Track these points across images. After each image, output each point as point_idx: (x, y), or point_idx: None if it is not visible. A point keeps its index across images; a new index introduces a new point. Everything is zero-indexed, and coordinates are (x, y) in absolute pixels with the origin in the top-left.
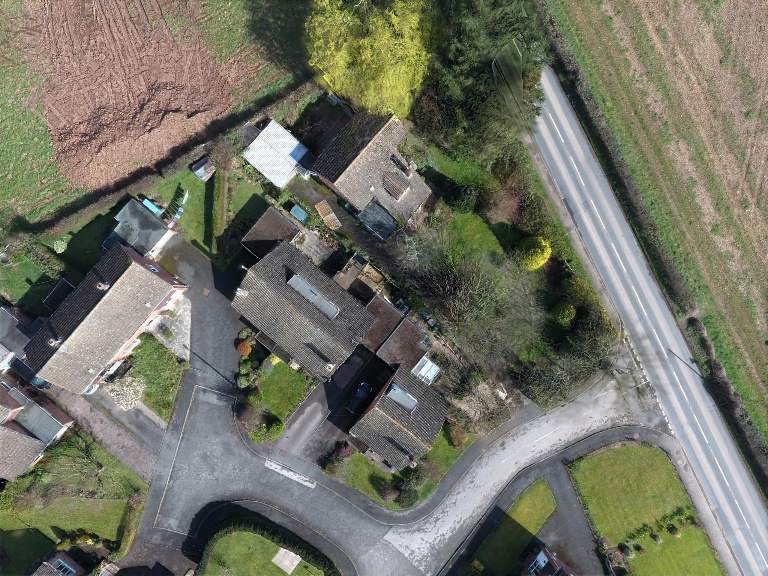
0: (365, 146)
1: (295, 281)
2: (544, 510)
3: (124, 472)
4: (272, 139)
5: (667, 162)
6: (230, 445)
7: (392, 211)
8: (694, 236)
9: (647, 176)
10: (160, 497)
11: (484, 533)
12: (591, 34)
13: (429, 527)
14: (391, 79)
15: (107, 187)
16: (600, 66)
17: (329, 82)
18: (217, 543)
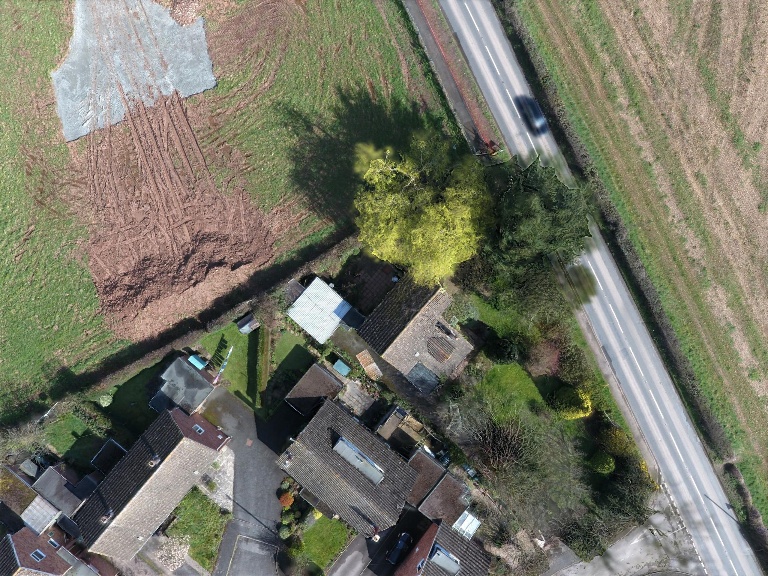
0: (412, 318)
1: (341, 447)
2: None
3: None
4: (316, 297)
5: (705, 308)
6: None
7: (435, 371)
8: (731, 382)
9: (685, 322)
10: None
11: None
12: (630, 181)
13: None
14: (440, 260)
15: (151, 338)
16: (639, 213)
17: (377, 255)
18: None
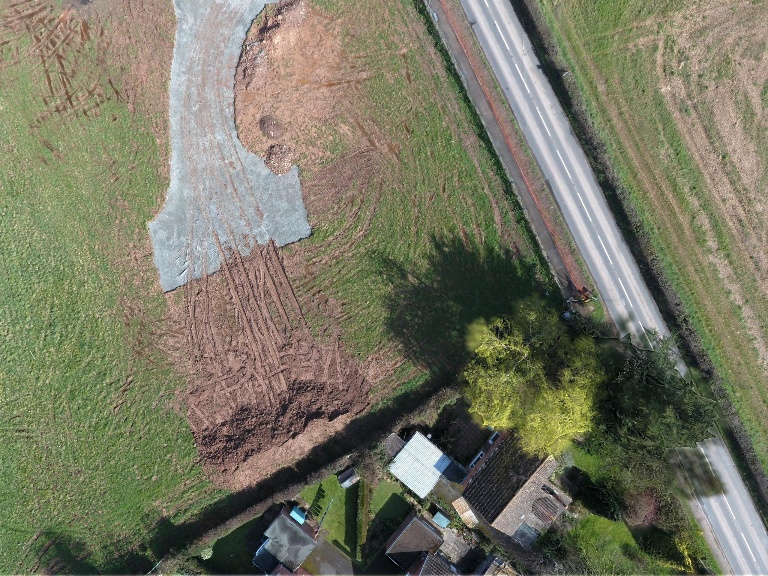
0: (521, 487)
1: None
2: None
3: None
4: (417, 451)
5: None
6: None
7: (537, 527)
8: None
9: None
10: None
11: None
12: (720, 324)
13: None
14: None
15: (249, 487)
16: (729, 355)
17: None
18: None
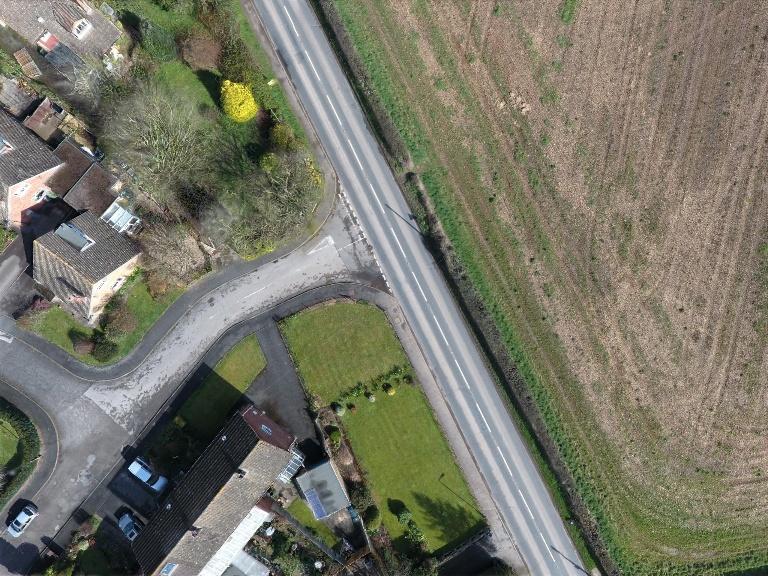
0: None
1: None
2: (253, 367)
3: None
4: None
5: (387, 13)
6: None
7: (74, 49)
8: (415, 90)
9: (366, 27)
10: None
11: (190, 390)
12: None
13: (132, 384)
14: None
15: None
16: None
17: None
18: None
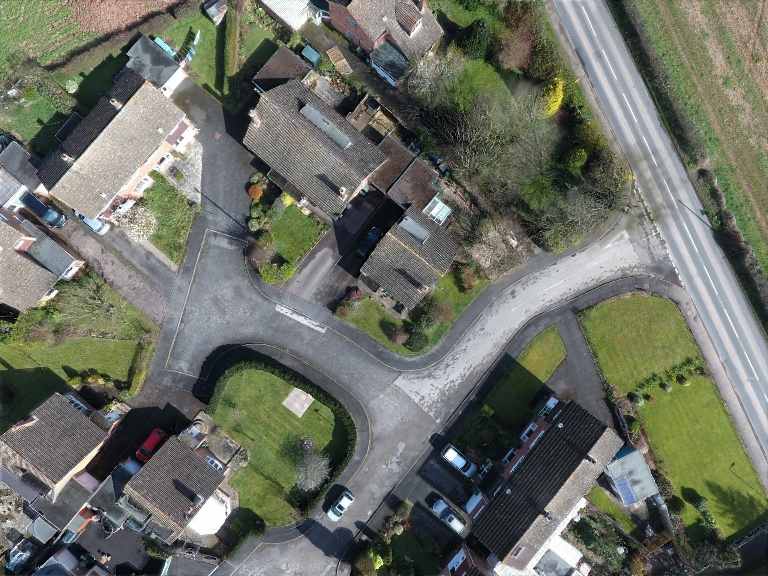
0: None
1: (307, 110)
2: (554, 358)
3: (135, 314)
4: None
5: (679, 14)
6: (241, 289)
7: (404, 48)
8: (705, 89)
9: (659, 28)
10: (171, 339)
11: (494, 380)
12: None
13: (439, 373)
14: None
15: (118, 31)
16: None
17: None
18: (228, 385)
